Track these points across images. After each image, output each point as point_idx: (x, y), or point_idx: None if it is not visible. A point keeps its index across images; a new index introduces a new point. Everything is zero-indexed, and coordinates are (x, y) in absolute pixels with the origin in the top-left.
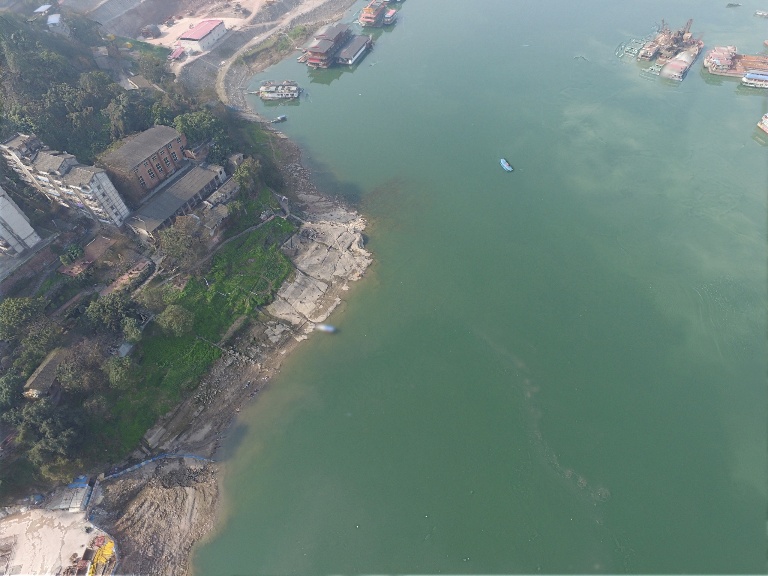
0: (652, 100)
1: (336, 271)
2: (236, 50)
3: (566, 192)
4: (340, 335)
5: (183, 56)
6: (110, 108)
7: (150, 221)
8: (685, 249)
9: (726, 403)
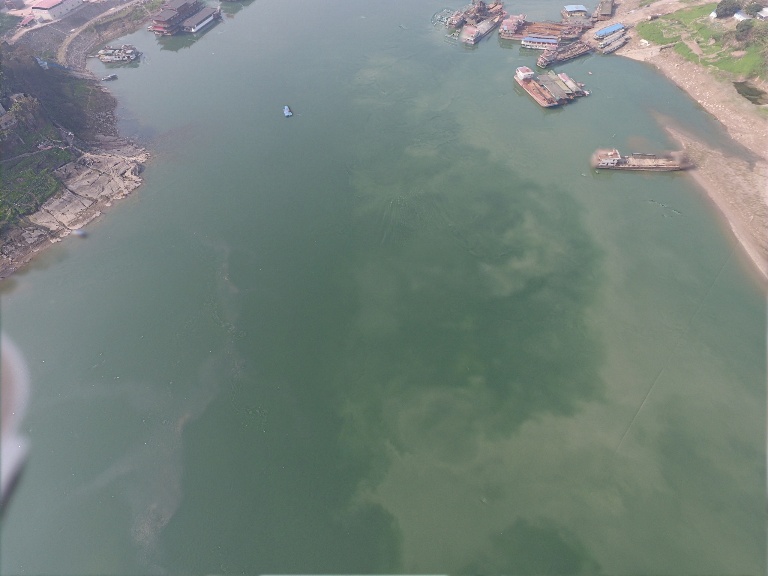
0: (439, 59)
1: (104, 191)
2: (89, 19)
3: (330, 132)
4: (90, 238)
5: (33, 23)
6: None
7: None
8: (400, 171)
9: (365, 273)
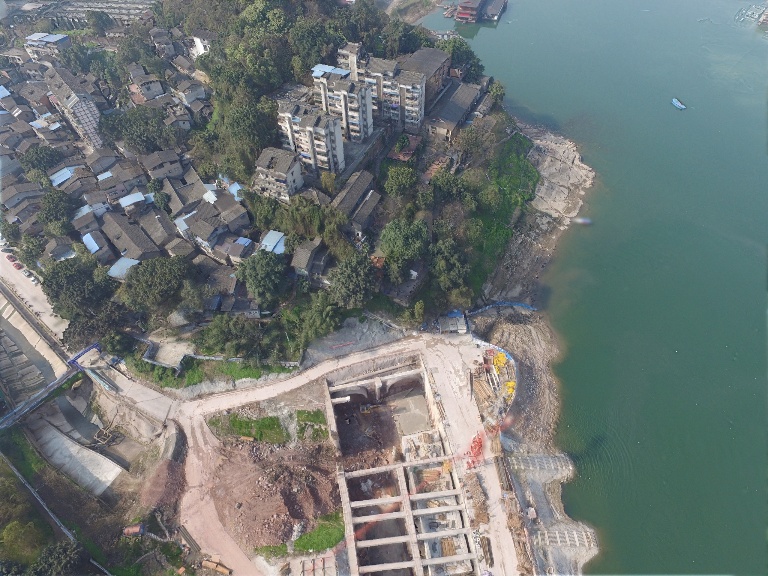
0: None
1: (571, 179)
2: (389, 3)
3: (738, 126)
4: (594, 227)
5: None
6: (388, 30)
7: (449, 122)
8: None
9: None
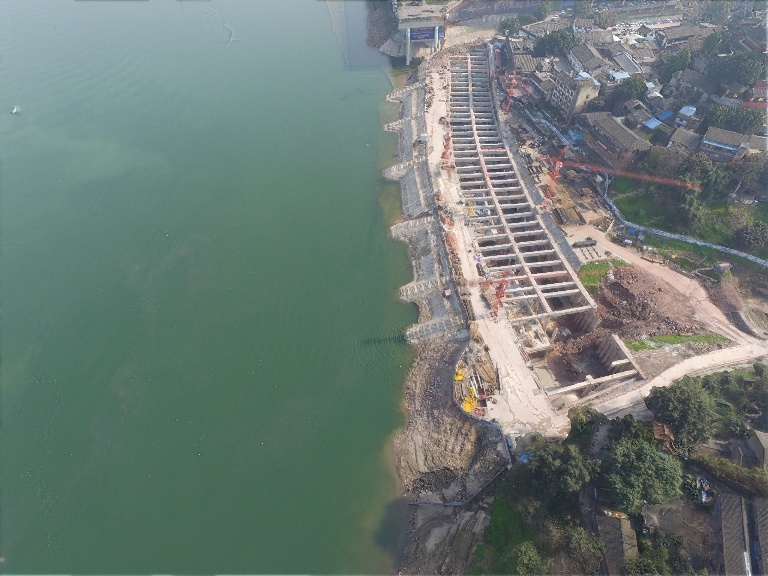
0: None
1: None
2: None
3: None
4: None
5: None
6: None
7: None
8: None
9: None
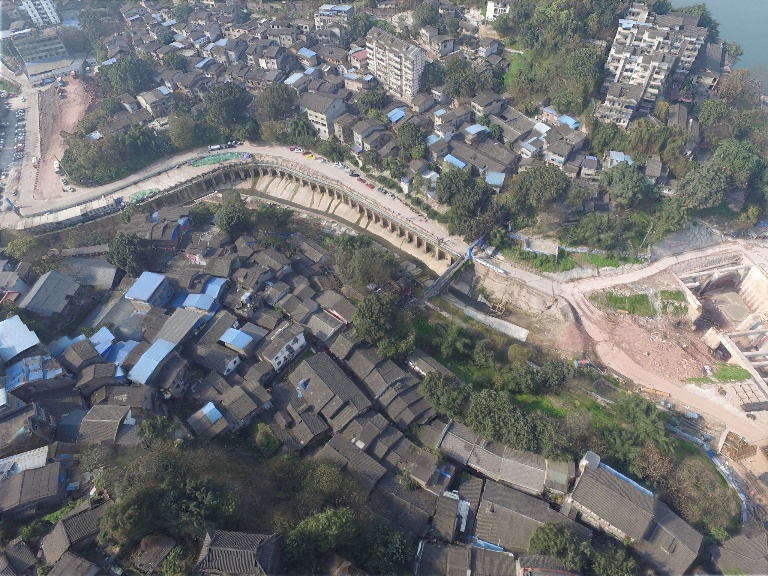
0: None
1: None
2: None
3: None
4: None
5: None
6: None
7: (714, 72)
8: None
9: None
